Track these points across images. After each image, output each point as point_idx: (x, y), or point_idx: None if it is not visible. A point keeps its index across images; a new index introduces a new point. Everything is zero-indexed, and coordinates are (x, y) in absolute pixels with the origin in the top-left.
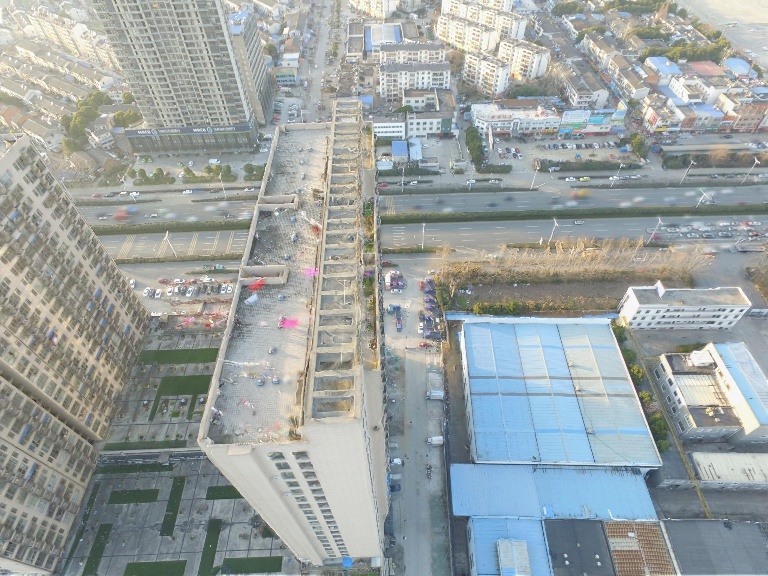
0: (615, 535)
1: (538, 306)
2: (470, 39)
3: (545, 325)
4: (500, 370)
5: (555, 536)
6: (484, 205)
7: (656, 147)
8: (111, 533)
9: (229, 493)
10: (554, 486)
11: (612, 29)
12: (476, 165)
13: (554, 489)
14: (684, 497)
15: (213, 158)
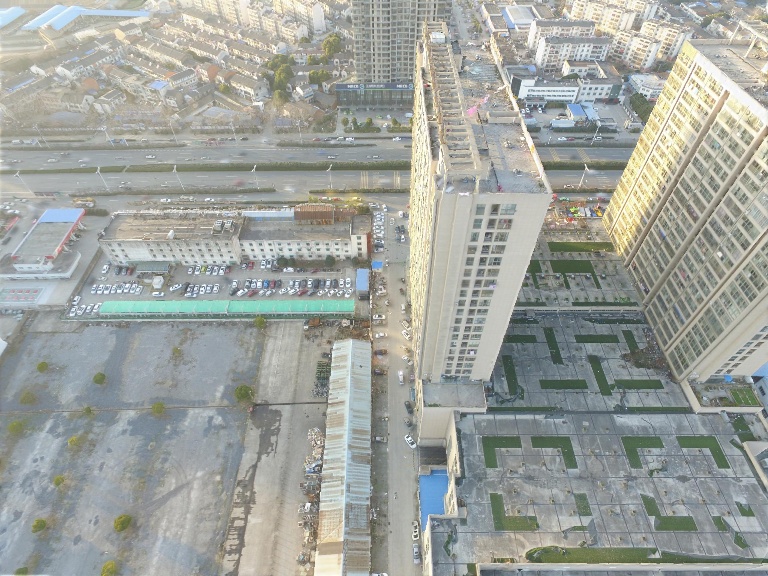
0: None
1: None
2: (608, 20)
3: None
4: None
5: None
6: None
7: None
8: (514, 361)
9: (593, 339)
10: None
11: (732, 16)
12: None
13: None
14: None
15: None
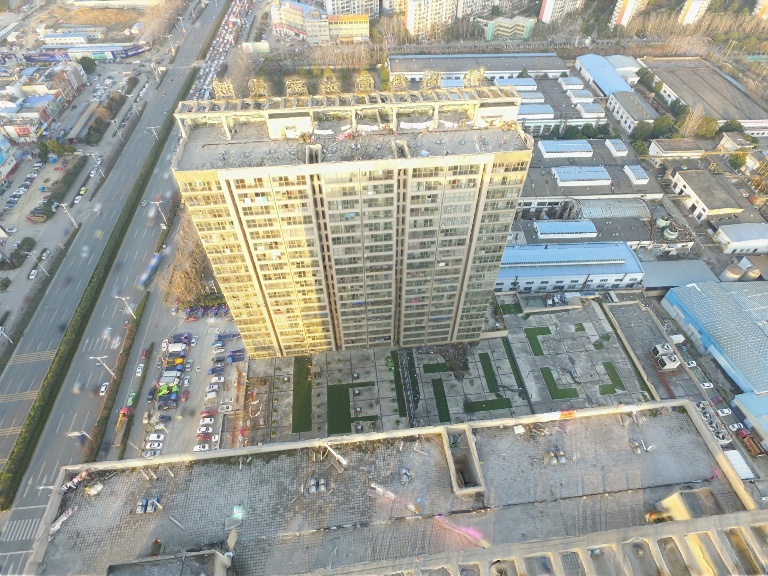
0: None
1: None
2: None
3: None
4: None
5: None
6: (84, 266)
7: (63, 142)
8: None
9: (442, 403)
10: None
11: None
12: (1, 268)
13: None
14: None
15: None
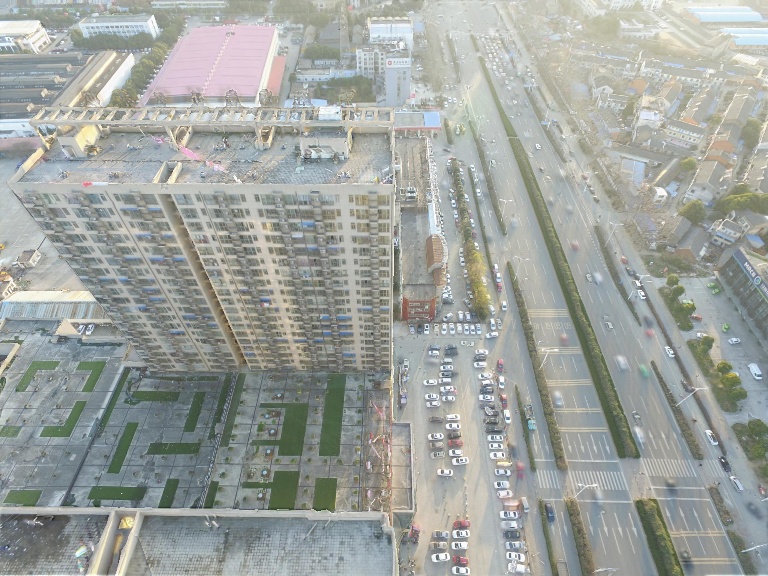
0: None
1: None
2: None
3: None
4: None
5: None
6: None
7: None
8: (170, 402)
9: (165, 503)
10: None
11: None
12: None
13: None
14: None
15: (763, 367)
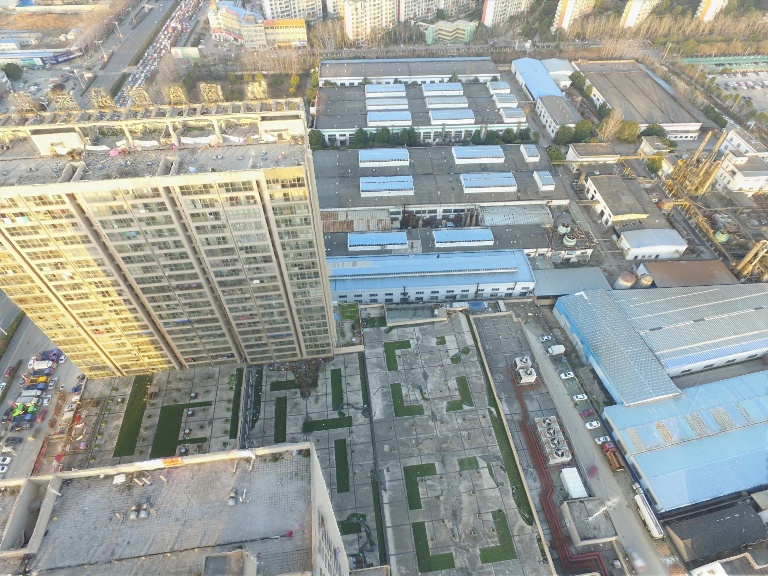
0: None
1: None
2: None
3: None
4: None
5: None
6: None
7: None
8: None
9: (281, 423)
10: None
11: None
12: None
13: None
14: None
15: None
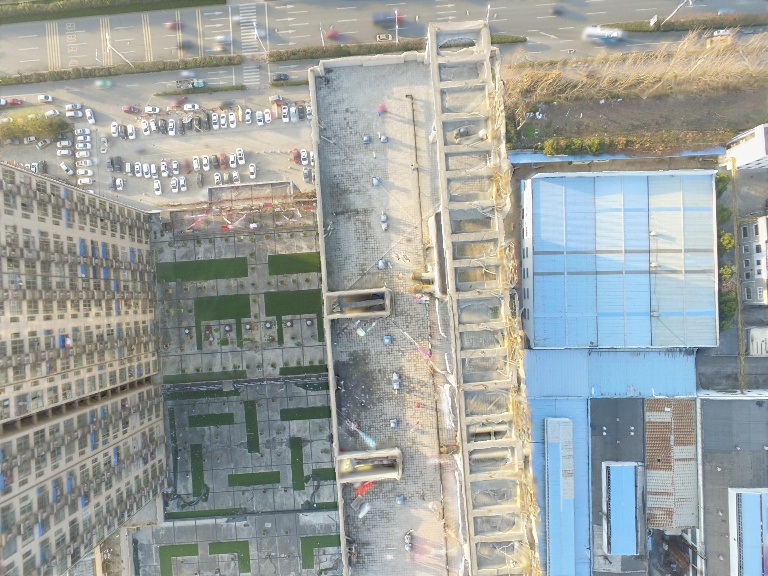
0: (653, 410)
1: (629, 144)
2: None
3: (633, 178)
4: (570, 243)
5: (598, 412)
6: None
7: None
8: (203, 452)
9: (302, 415)
10: (606, 369)
11: None
12: None
13: (605, 371)
14: (723, 360)
15: None
